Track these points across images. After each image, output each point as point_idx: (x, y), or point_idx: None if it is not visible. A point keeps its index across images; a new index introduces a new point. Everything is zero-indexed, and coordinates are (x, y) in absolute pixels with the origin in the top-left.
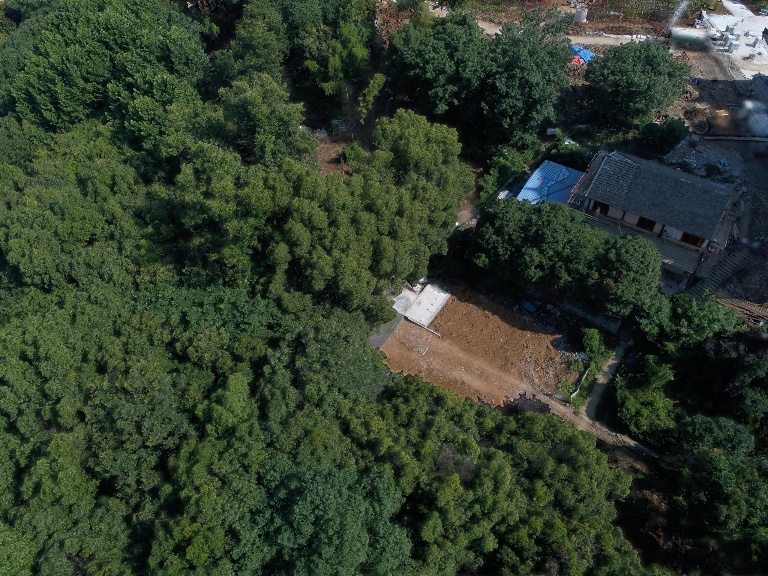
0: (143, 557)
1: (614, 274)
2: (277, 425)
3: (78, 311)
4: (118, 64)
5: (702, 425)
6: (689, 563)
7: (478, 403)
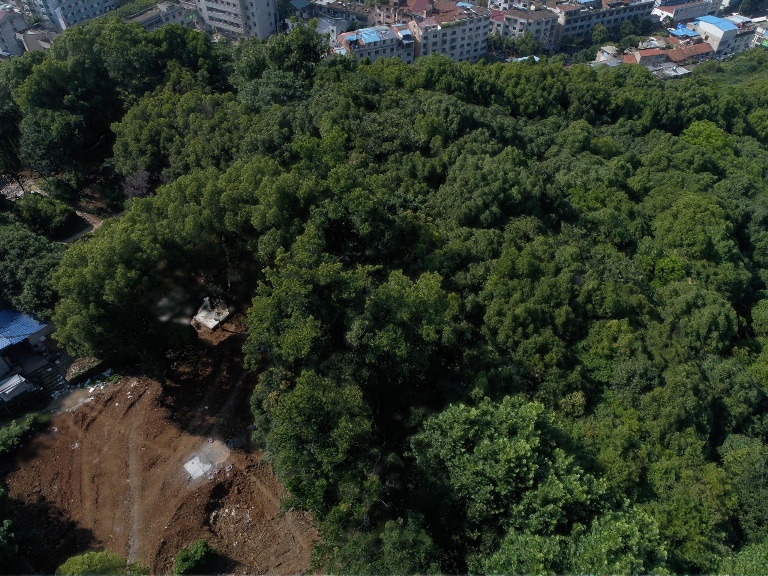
0: (372, 110)
1: (4, 215)
2: (300, 110)
3: (465, 190)
4: (670, 575)
5: (47, 139)
6: (94, 172)
7: (176, 164)
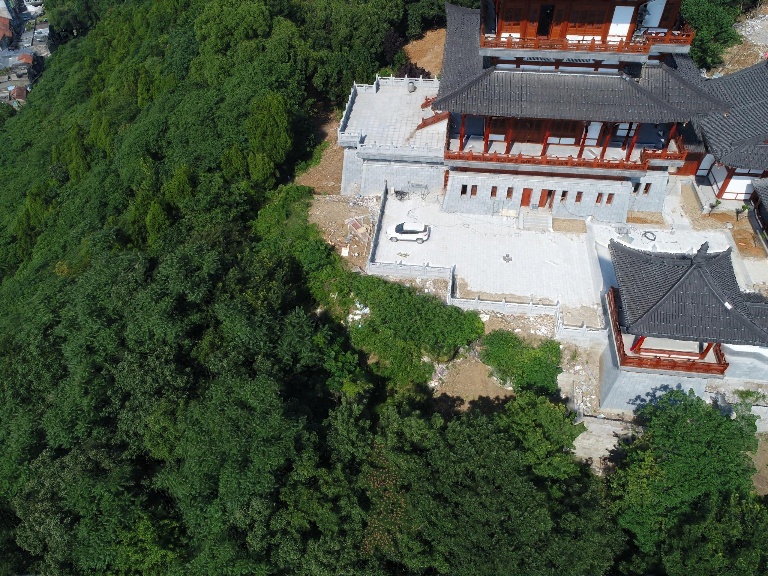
0: None
1: None
2: None
3: None
4: None
5: None
6: None
7: None
